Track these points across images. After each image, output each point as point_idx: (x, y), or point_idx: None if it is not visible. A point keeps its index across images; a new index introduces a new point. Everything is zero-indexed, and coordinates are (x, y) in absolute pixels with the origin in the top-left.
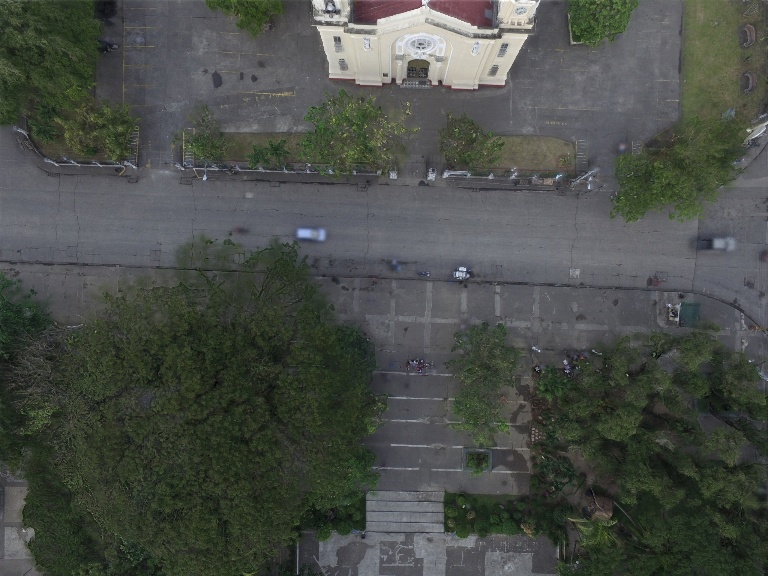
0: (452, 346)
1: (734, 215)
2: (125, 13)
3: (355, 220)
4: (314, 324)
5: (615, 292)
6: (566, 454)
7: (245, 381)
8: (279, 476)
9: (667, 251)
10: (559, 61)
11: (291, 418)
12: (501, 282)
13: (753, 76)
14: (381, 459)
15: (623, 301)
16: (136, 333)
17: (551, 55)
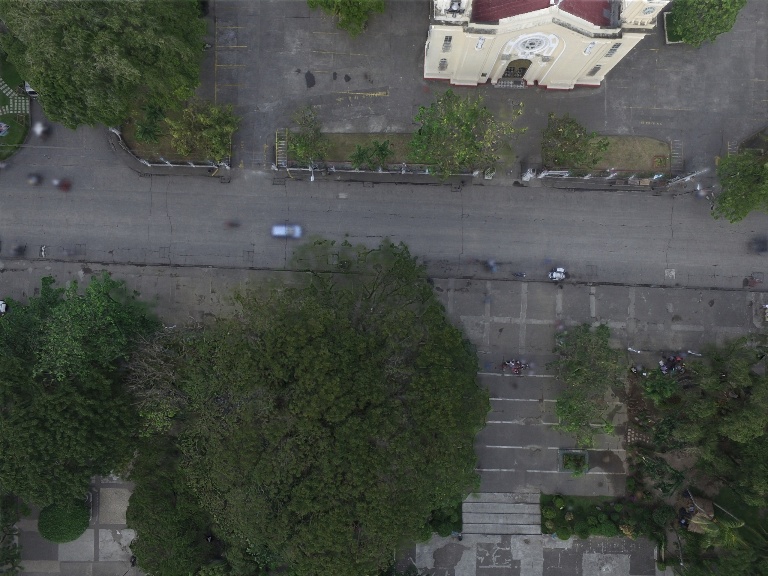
0: (548, 347)
1: None
2: (217, 13)
3: (449, 221)
4: (442, 326)
5: (711, 293)
6: (663, 455)
7: (381, 383)
8: (414, 479)
9: (763, 251)
10: (654, 61)
11: (425, 420)
12: (596, 283)
13: None
14: (477, 460)
15: (719, 302)
16: (272, 335)
17: (646, 55)
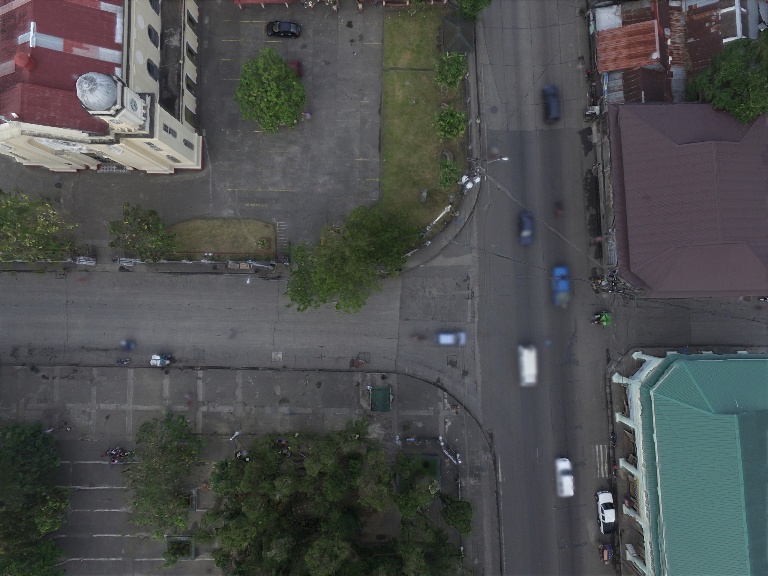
0: None
1: (435, 294)
2: None
3: (54, 308)
4: None
5: (318, 374)
6: None
7: None
8: None
9: (369, 332)
10: (258, 142)
11: None
12: (204, 367)
13: (450, 154)
14: (83, 551)
15: (326, 383)
16: None
17: (250, 137)
